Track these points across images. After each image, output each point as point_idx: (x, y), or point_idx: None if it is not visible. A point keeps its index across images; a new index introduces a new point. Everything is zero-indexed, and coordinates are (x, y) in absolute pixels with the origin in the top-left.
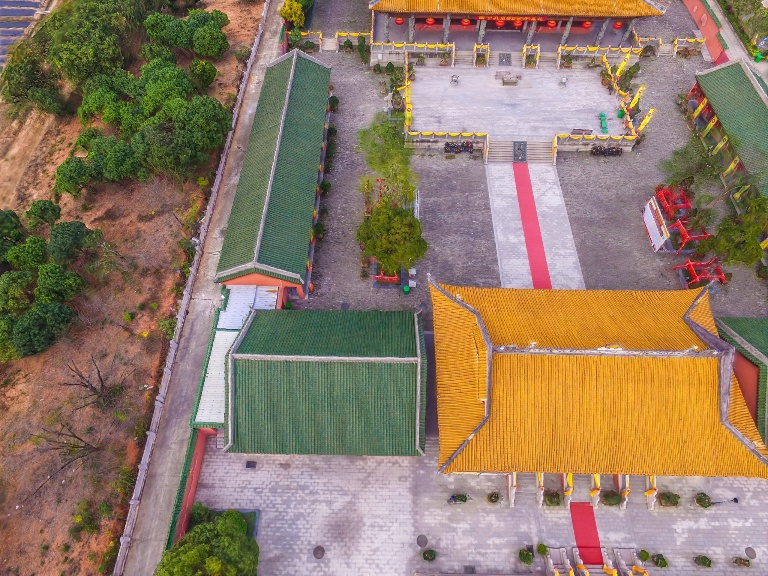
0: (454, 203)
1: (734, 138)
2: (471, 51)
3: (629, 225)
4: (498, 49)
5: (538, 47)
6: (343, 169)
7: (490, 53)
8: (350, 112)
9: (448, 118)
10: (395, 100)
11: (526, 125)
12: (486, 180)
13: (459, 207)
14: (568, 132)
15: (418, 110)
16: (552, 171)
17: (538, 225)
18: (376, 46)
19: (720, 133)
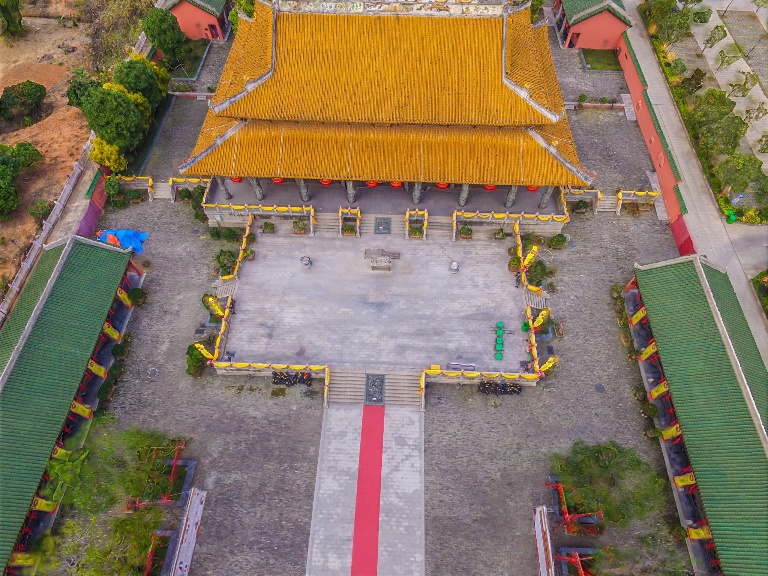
0: (263, 484)
1: (676, 394)
2: (337, 214)
3: (512, 535)
4: (375, 210)
5: (425, 212)
6: (122, 414)
7: (363, 217)
8: (161, 307)
9: (284, 328)
10: (206, 307)
11: (390, 343)
12: (319, 438)
13: (268, 493)
14: (447, 357)
15: (246, 313)
16: (417, 422)
17: (377, 532)
18: (209, 207)
19: (661, 369)
